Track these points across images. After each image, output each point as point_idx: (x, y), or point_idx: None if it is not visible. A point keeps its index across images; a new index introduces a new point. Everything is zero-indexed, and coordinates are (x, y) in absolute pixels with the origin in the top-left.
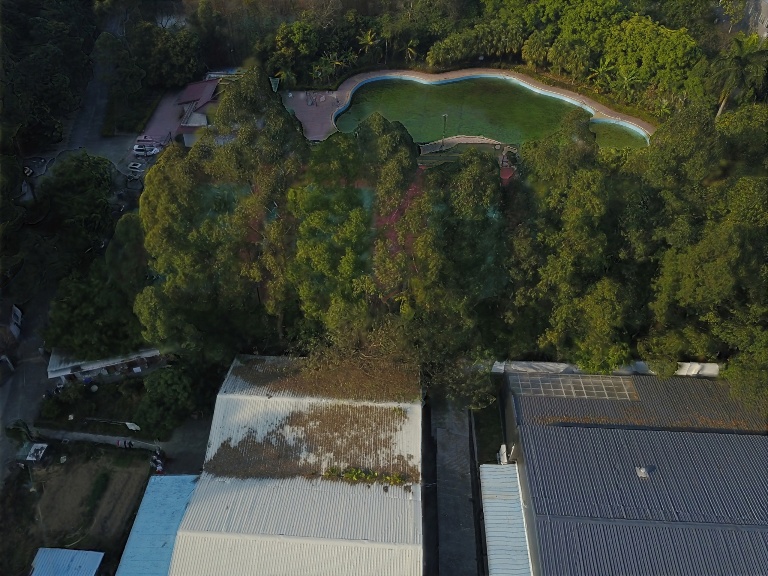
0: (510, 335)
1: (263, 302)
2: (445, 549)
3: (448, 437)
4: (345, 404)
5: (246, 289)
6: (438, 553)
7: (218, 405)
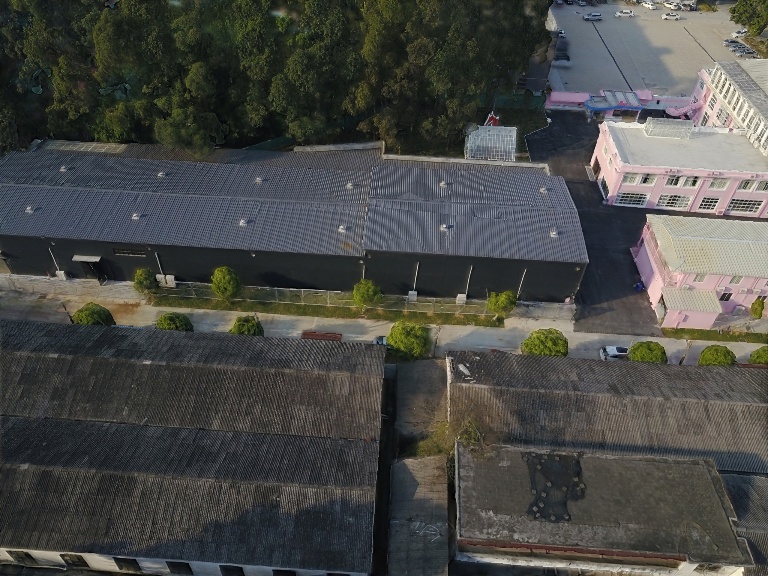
0: None
1: None
2: None
3: None
4: None
5: None
6: None
7: None
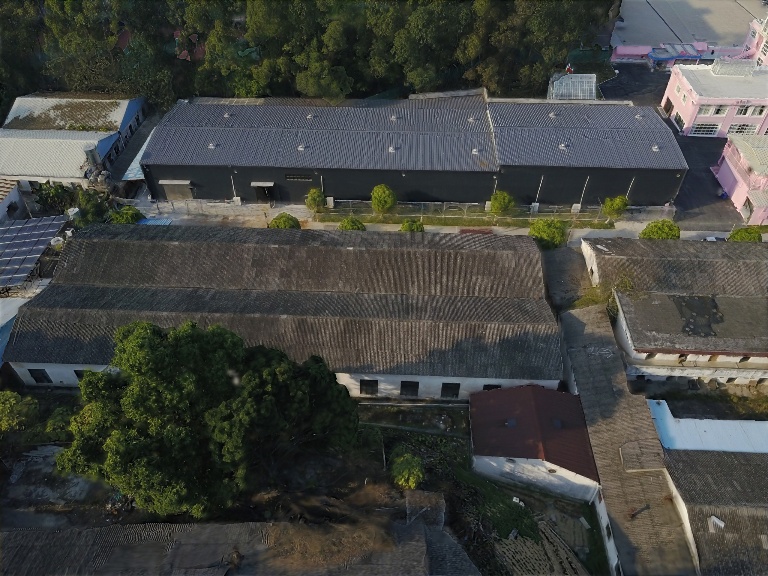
0: (195, 75)
1: (42, 46)
2: (123, 157)
3: (149, 124)
4: (87, 101)
5: (31, 38)
6: (118, 158)
7: (16, 102)
